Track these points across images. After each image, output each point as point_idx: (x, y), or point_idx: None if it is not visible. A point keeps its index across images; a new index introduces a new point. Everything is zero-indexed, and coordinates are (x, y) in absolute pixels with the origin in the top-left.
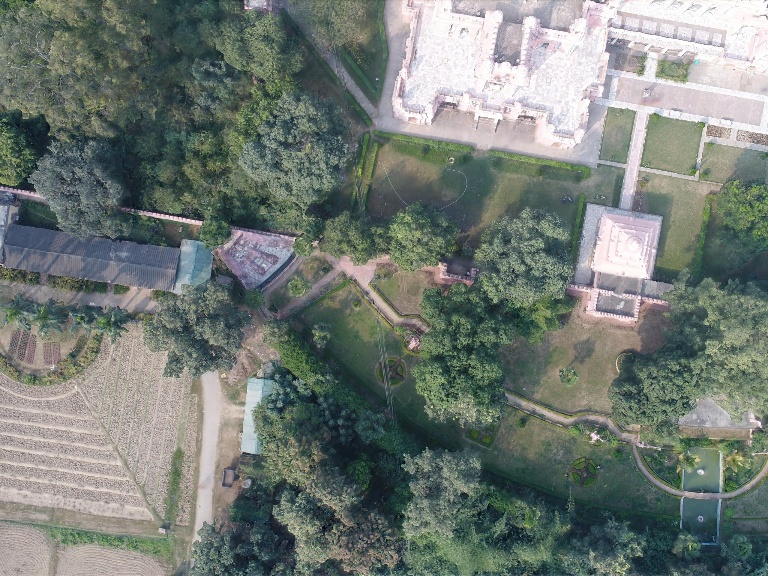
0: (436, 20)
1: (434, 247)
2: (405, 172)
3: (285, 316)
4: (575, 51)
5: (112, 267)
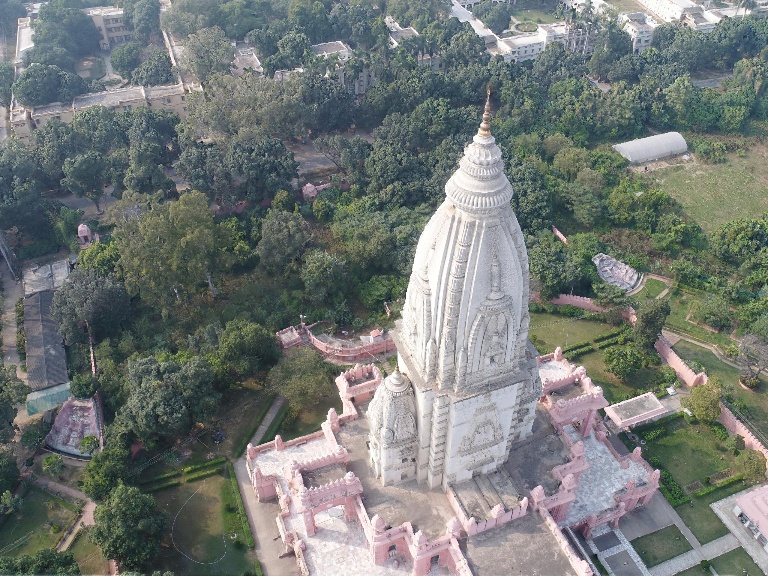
0: (322, 425)
1: (115, 530)
2: (205, 504)
3: (28, 478)
4: (383, 567)
5: (39, 350)
